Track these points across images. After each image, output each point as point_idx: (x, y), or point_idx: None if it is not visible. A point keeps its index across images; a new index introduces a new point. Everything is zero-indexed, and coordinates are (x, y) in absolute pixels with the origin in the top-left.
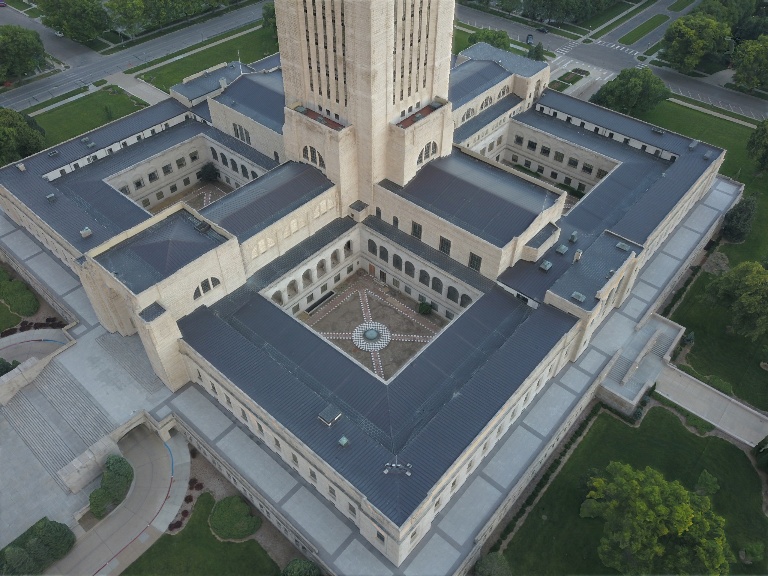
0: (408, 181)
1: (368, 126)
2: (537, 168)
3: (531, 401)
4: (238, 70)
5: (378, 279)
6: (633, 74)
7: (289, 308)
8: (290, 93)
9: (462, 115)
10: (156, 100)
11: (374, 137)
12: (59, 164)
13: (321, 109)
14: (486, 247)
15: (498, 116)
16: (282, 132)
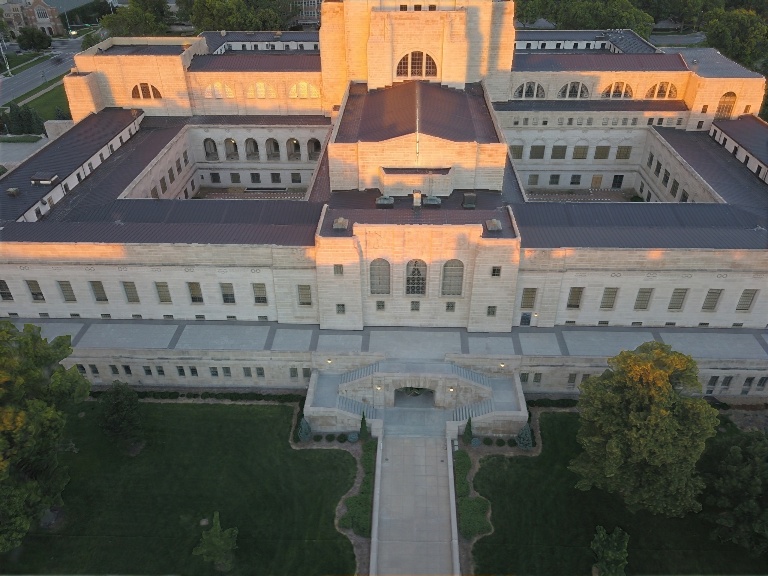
0: (377, 87)
1: None
2: None
3: (222, 319)
4: None
5: None
6: None
7: (226, 170)
8: None
9: (560, 85)
10: None
11: (349, 16)
12: (245, 40)
13: None
14: None
15: (623, 111)
16: None
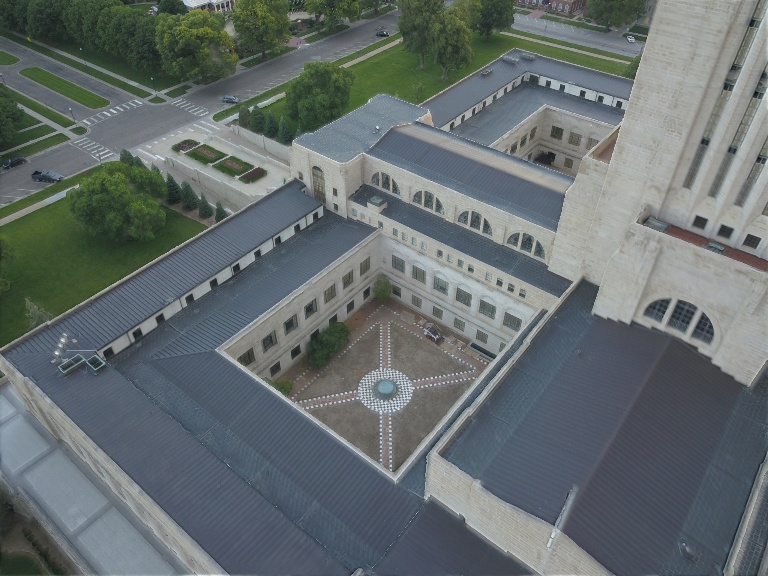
0: None
1: None
2: None
3: None
4: None
5: None
6: (313, 77)
7: None
8: None
9: None
10: None
11: None
12: None
13: None
14: None
15: None
16: (762, 402)
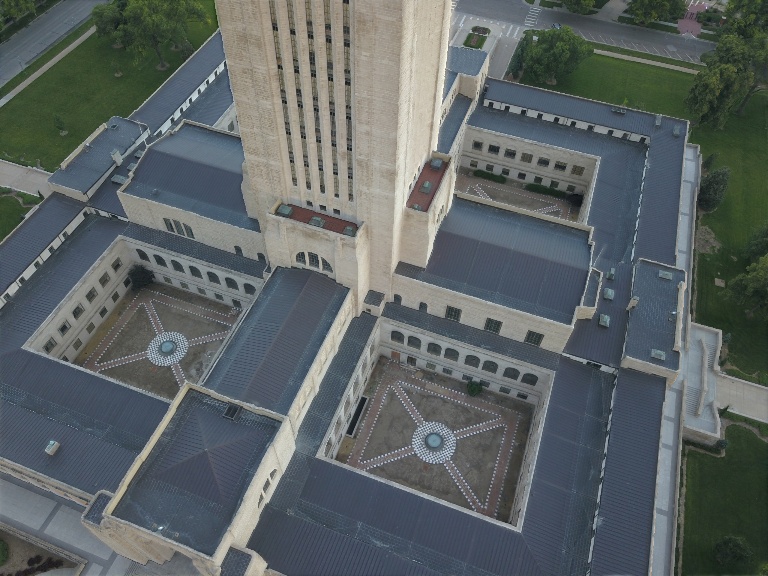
0: (428, 259)
1: (388, 222)
2: (501, 171)
3: None
4: (124, 130)
5: (405, 364)
6: (554, 36)
7: (336, 444)
8: (262, 190)
9: None
10: (5, 177)
11: (394, 230)
12: None
13: (310, 204)
14: (552, 326)
15: (458, 128)
16: (241, 222)
